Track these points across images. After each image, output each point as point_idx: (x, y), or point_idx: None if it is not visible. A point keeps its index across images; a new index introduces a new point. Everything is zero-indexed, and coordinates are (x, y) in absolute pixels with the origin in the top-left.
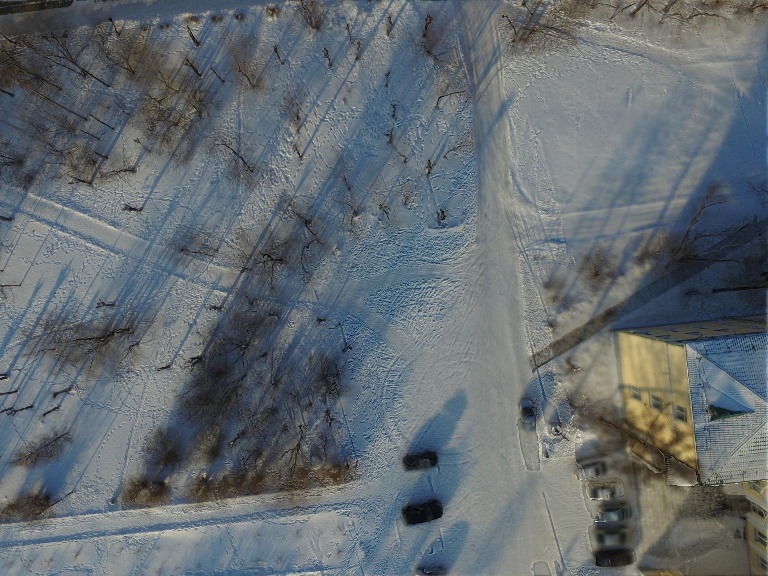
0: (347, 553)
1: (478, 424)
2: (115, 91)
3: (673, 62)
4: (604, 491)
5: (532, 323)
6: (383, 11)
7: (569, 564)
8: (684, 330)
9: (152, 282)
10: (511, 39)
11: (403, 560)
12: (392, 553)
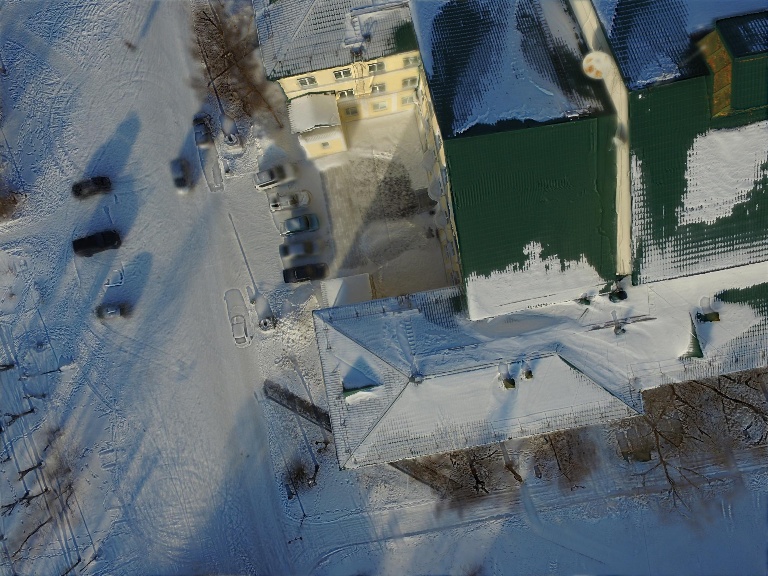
0: (21, 296)
1: (154, 146)
2: None
3: None
4: (283, 198)
5: (203, 33)
6: None
7: (262, 288)
8: None
9: None
10: None
11: (84, 300)
12: (72, 293)
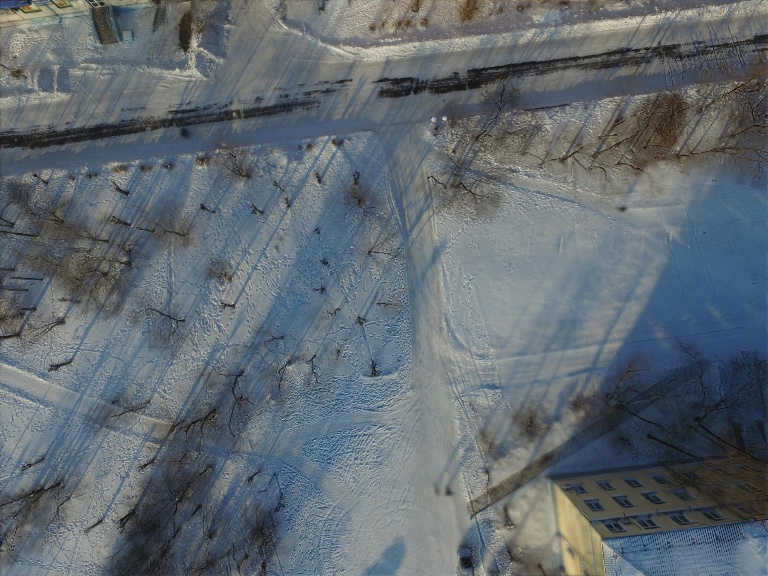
0: None
1: (417, 572)
2: (43, 241)
3: (603, 207)
4: None
5: (469, 469)
6: (314, 158)
7: None
8: (616, 486)
9: (83, 435)
10: (442, 186)
11: None
12: None
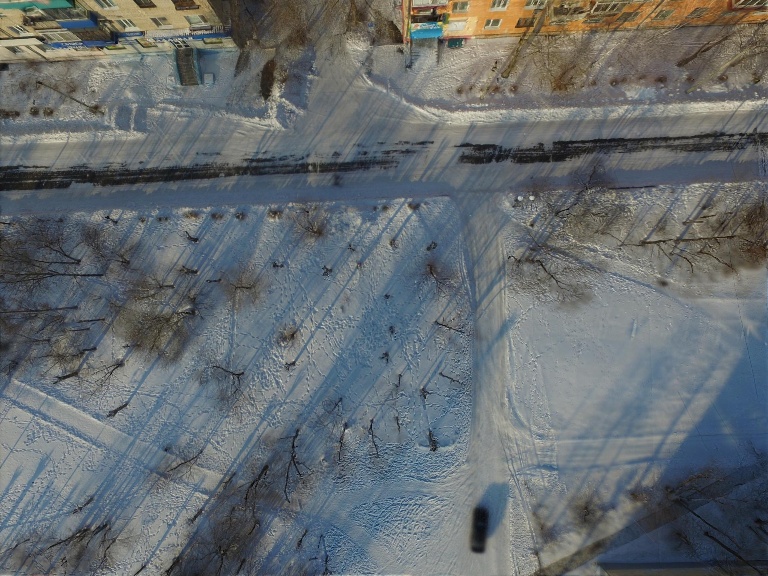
0: None
1: None
2: (108, 280)
3: (681, 295)
4: None
5: (518, 549)
6: (388, 220)
7: None
8: None
9: (133, 479)
10: None
11: None
12: None
